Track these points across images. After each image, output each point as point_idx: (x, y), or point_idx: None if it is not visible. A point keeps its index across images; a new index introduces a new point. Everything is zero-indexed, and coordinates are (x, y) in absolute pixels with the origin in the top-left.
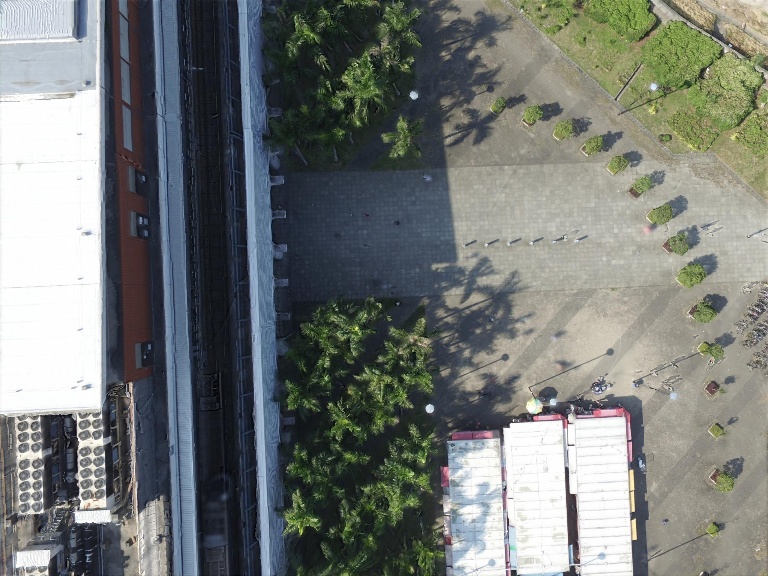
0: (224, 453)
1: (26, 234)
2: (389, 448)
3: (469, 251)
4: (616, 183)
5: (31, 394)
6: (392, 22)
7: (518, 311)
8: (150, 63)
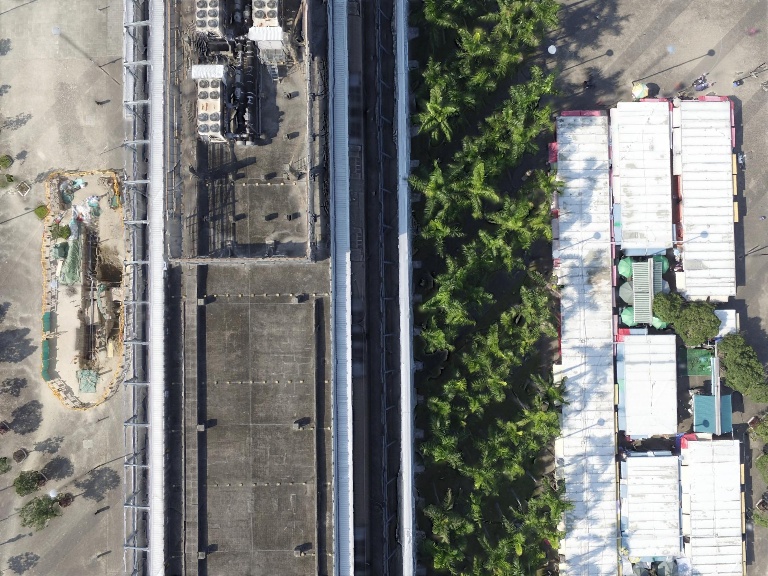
0: (362, 61)
1: None
2: (510, 92)
3: None
4: None
5: None
6: None
7: (623, 10)
8: None
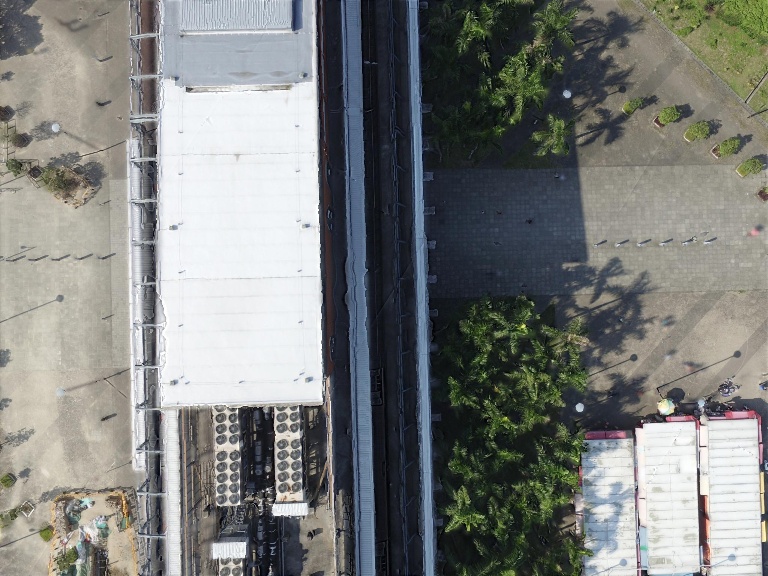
0: (385, 448)
1: (246, 225)
2: (536, 446)
3: (599, 251)
4: (745, 186)
5: (254, 386)
6: (546, 20)
7: (647, 312)
8: (334, 56)
